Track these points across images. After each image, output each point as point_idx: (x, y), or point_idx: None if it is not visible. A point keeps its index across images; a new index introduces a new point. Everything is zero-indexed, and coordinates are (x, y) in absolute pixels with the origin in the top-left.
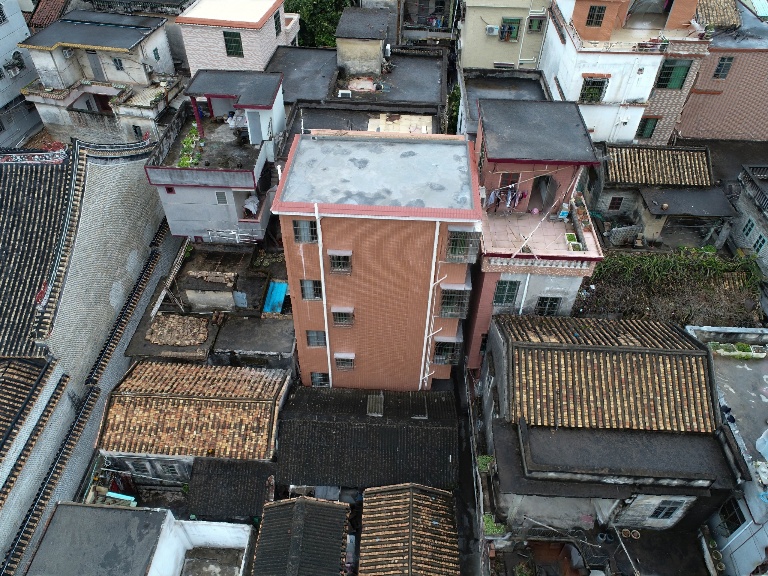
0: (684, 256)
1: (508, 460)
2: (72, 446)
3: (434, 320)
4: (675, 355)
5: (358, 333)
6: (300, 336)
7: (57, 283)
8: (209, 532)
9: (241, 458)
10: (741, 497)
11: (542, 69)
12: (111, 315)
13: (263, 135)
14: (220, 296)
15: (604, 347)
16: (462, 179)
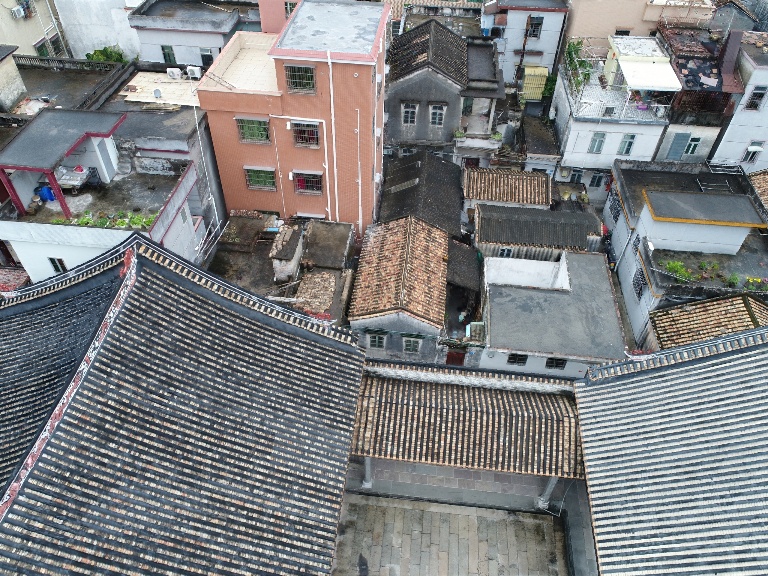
0: None
1: (487, 94)
2: None
3: None
4: None
5: None
6: None
7: None
8: None
9: None
10: None
11: (77, 23)
12: None
13: (112, 163)
14: None
15: None
16: (347, 6)
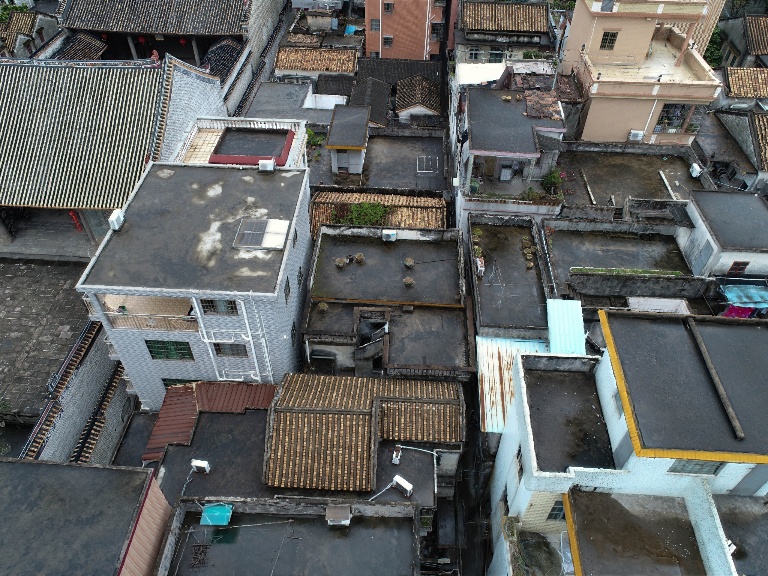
0: (559, 2)
1: (459, 37)
2: (258, 77)
3: (431, 10)
4: (534, 5)
5: (395, 21)
6: (368, 24)
7: (251, 2)
8: (327, 103)
9: (341, 71)
10: (552, 46)
11: None
12: (263, 43)
13: None
14: (324, 21)
15: (503, 1)
16: None
